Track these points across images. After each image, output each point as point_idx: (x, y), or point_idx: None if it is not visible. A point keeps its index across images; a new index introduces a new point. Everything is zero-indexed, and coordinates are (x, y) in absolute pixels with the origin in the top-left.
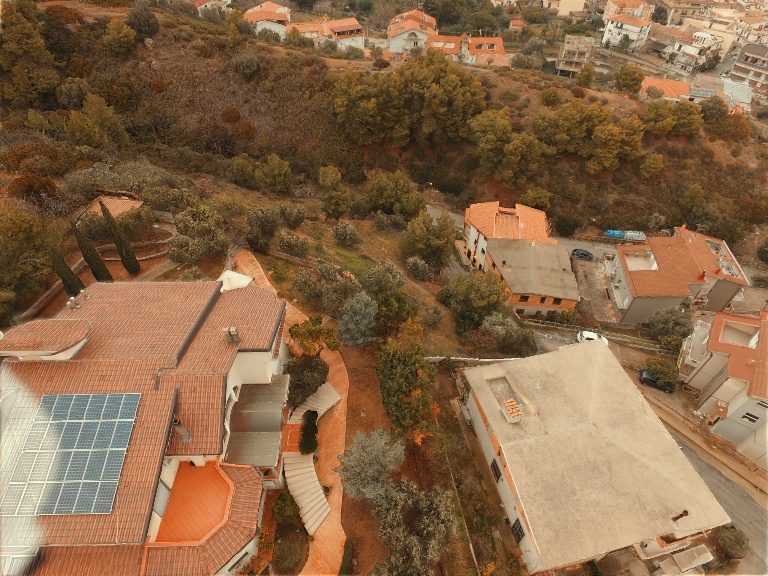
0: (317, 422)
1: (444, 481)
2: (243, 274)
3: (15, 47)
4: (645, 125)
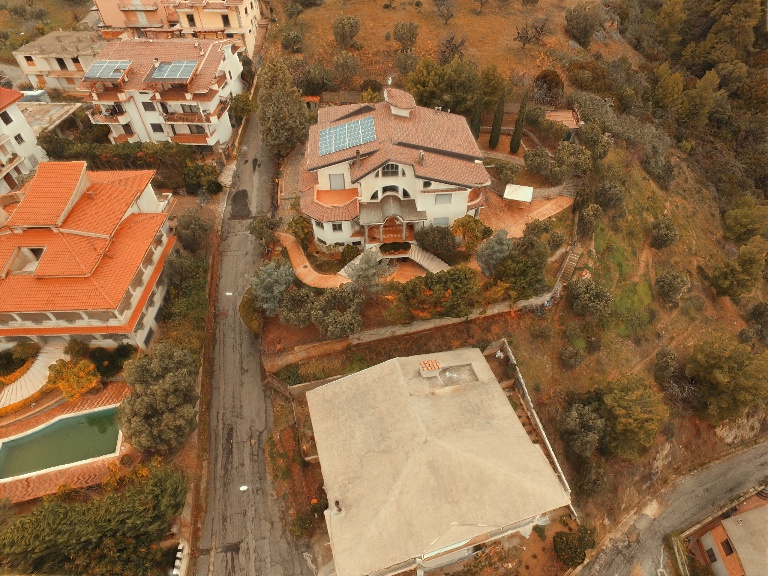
0: (415, 265)
1: (385, 355)
2: (543, 205)
3: (728, 19)
4: None
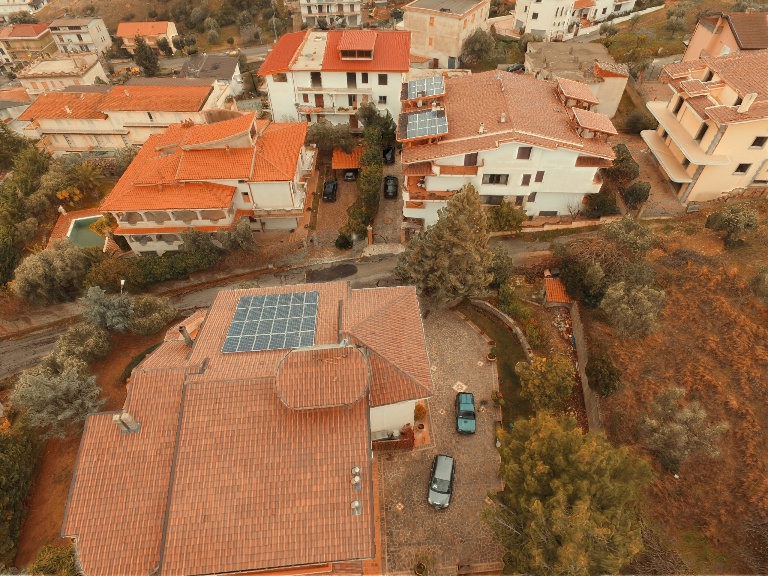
0: None
1: None
2: None
3: None
4: None
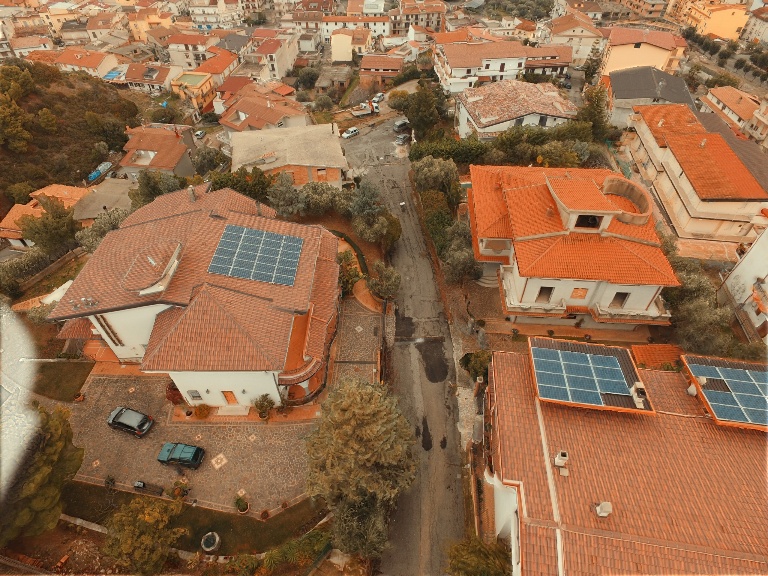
0: None
1: None
2: None
3: None
4: (8, 95)
